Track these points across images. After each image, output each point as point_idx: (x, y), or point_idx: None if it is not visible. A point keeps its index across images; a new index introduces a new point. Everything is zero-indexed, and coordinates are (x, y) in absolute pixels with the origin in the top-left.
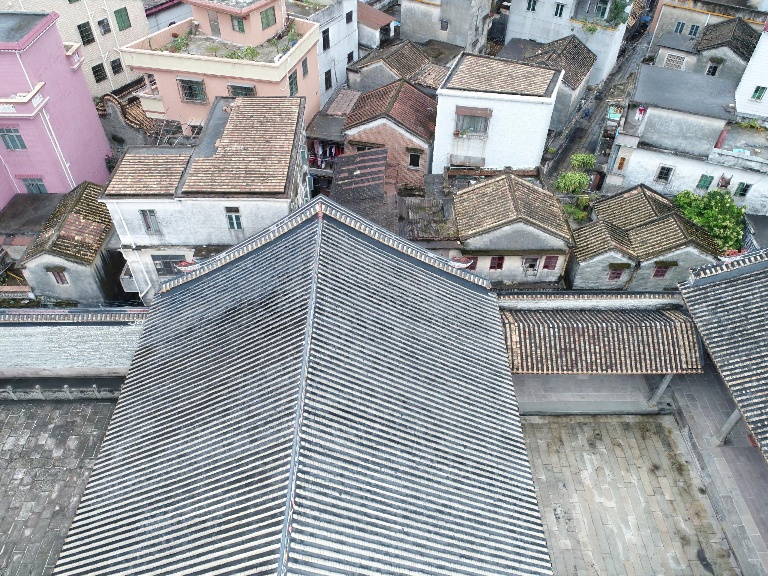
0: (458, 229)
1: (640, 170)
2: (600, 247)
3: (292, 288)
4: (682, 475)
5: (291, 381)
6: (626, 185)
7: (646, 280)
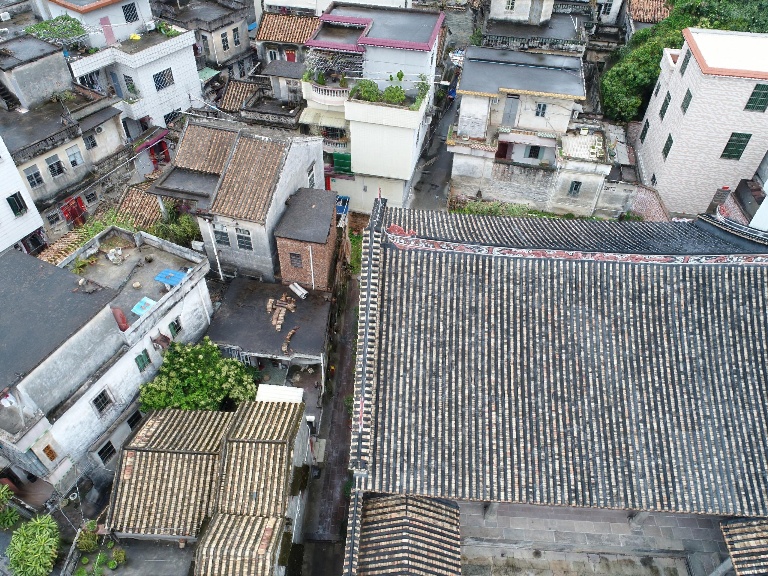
0: None
1: (76, 431)
2: (257, 574)
3: None
4: (520, 569)
5: None
6: (78, 457)
7: (292, 512)
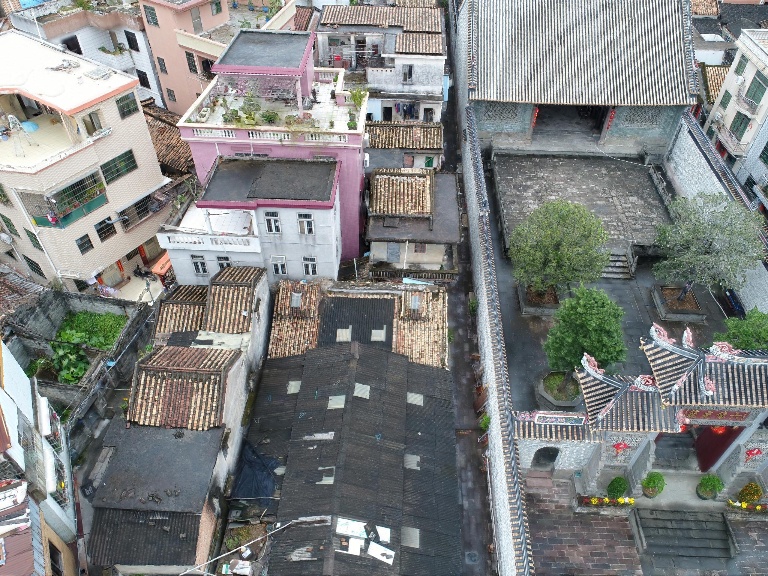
0: (427, 7)
1: None
2: None
3: (518, 6)
4: None
5: (575, 2)
6: None
7: None
